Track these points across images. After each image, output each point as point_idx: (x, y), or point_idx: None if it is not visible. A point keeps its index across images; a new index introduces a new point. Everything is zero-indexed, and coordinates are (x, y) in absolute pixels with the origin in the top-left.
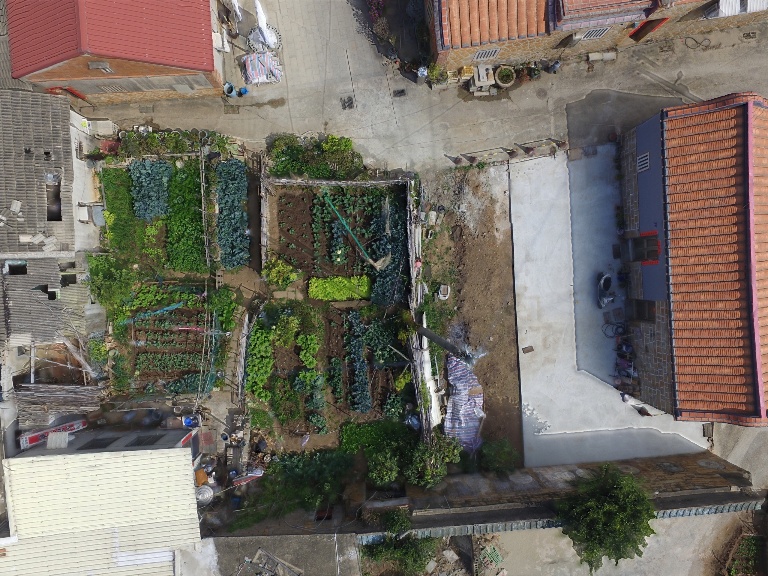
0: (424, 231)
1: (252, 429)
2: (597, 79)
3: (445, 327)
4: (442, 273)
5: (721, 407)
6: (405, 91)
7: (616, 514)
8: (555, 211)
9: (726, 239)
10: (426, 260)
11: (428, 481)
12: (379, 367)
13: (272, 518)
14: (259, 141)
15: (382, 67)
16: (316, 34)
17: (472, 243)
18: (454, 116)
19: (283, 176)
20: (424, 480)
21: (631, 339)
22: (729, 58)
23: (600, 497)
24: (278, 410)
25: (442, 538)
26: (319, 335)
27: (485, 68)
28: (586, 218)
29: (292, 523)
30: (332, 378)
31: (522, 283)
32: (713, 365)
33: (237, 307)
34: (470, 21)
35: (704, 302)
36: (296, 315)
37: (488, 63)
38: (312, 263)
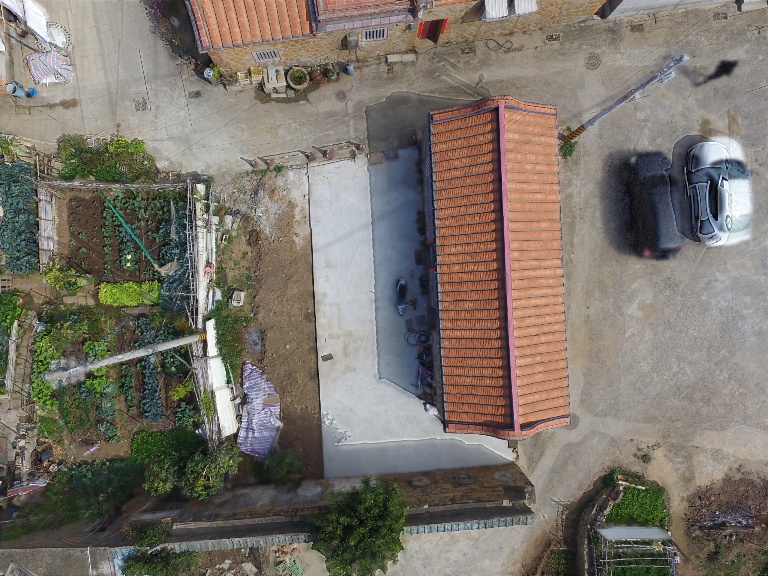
0: (219, 235)
1: (39, 437)
2: (397, 81)
3: (240, 334)
4: (239, 279)
5: (483, 419)
6: (201, 92)
7: (356, 530)
8: (355, 216)
9: (486, 246)
10: (221, 265)
11: (199, 493)
12: (170, 375)
13: (46, 530)
14: (50, 142)
15: (176, 67)
16: (108, 33)
17: (268, 248)
18: (250, 118)
19: (71, 178)
20: (195, 492)
21: (431, 347)
22: (532, 61)
23: (347, 512)
24: (66, 418)
25: (241, 550)
26: (111, 341)
27: (275, 69)
28: (387, 223)
29: (60, 535)
30: (123, 386)
31: (321, 289)
32: (476, 376)
33: (26, 312)
34: (228, 21)
35: (468, 311)
36: (82, 321)
37: (278, 64)
38: (103, 268)
